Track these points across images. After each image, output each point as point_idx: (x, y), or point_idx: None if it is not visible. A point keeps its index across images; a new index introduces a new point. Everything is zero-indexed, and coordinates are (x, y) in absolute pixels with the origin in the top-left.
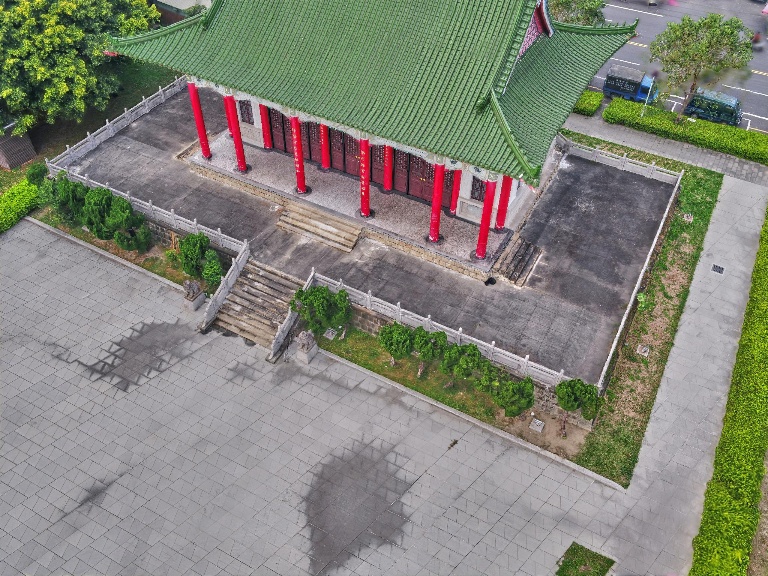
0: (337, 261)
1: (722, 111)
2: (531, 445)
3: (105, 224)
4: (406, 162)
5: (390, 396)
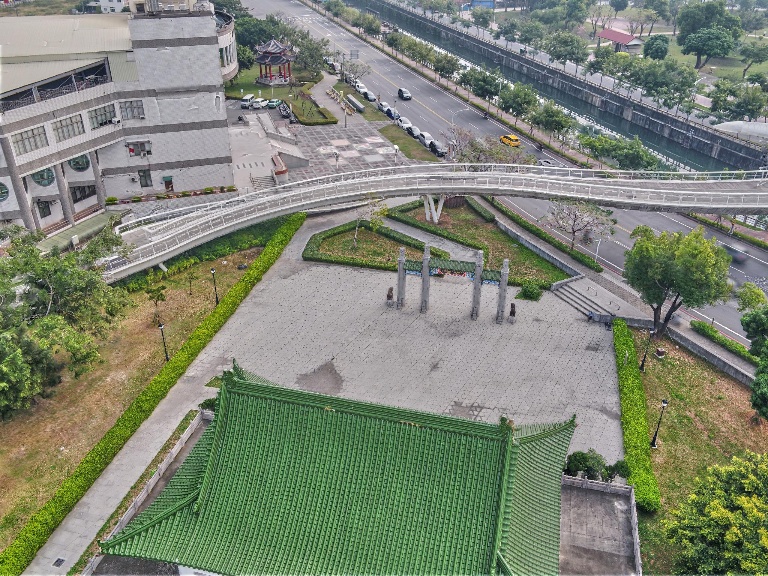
0: None
1: None
2: None
3: None
4: None
5: None
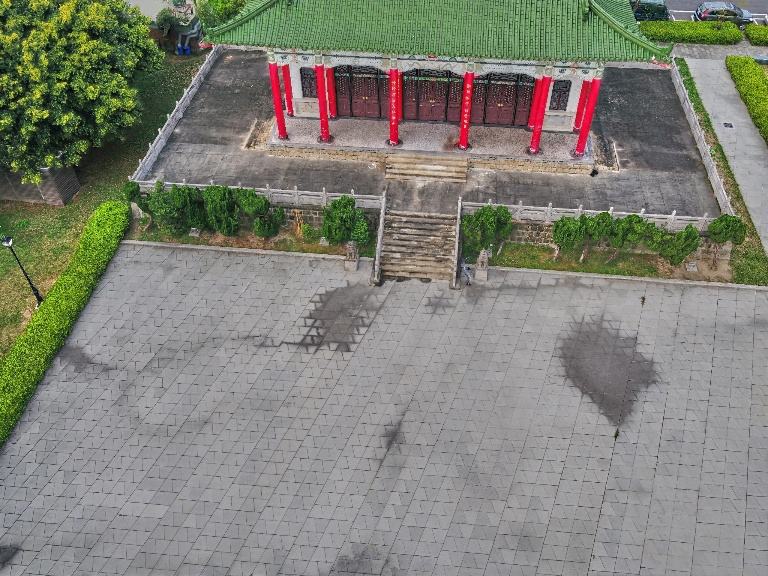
0: (462, 192)
1: (655, 11)
2: (698, 282)
3: (233, 218)
4: (484, 93)
5: (570, 283)
